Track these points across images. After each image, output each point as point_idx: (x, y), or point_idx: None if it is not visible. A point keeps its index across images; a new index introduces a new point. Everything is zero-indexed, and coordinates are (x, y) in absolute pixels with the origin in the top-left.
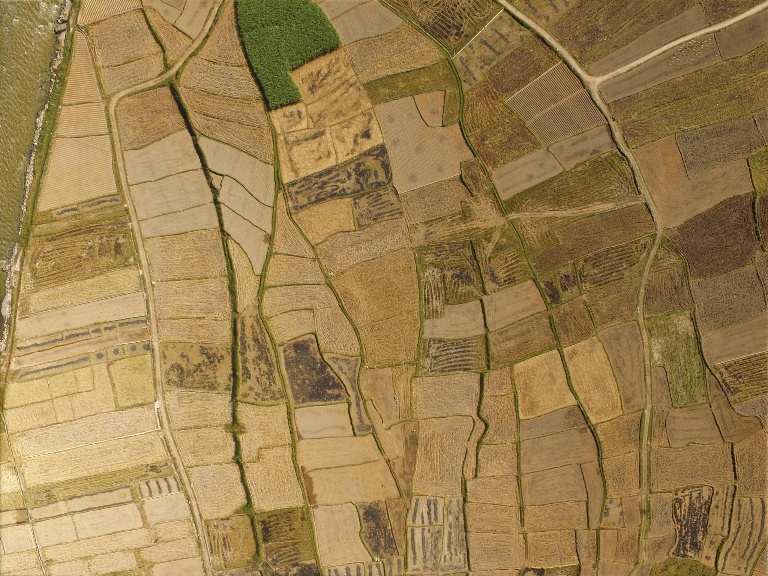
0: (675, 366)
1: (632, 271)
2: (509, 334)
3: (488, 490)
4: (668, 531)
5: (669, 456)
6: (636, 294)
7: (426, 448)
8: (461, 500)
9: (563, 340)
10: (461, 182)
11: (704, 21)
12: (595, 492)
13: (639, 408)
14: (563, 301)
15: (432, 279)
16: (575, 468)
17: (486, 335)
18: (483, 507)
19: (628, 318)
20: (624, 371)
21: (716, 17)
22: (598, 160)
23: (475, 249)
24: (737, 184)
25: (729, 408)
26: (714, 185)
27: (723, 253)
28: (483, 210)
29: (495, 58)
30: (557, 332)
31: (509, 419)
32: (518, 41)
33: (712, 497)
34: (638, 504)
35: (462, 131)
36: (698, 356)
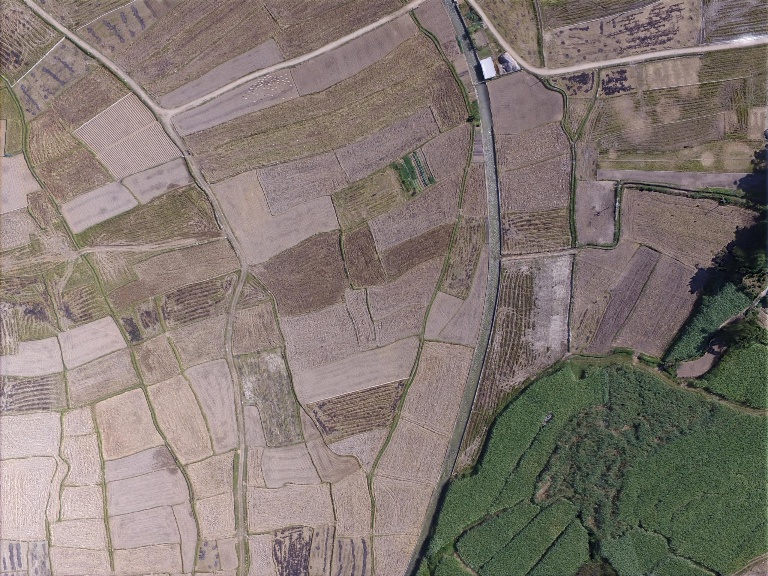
0: (268, 405)
1: (218, 308)
2: (88, 372)
3: (73, 534)
4: (269, 573)
5: (266, 497)
6: (223, 331)
7: (5, 490)
8: (47, 544)
9: (147, 378)
10: (29, 214)
11: (279, 56)
12: (188, 534)
13: (232, 448)
14: (145, 338)
15: (4, 314)
16: (167, 510)
17: (64, 373)
18: (69, 551)
19: (216, 356)
20: (214, 410)
21: (290, 52)
22: (176, 194)
23: (46, 284)
24: (322, 221)
25: (325, 448)
26: (298, 222)
27: (312, 290)
28: (54, 244)
29: (60, 87)
30: (140, 370)
31: (92, 460)
32: (84, 70)
33: (312, 538)
34: (234, 546)
35: (26, 162)
36: (291, 395)
